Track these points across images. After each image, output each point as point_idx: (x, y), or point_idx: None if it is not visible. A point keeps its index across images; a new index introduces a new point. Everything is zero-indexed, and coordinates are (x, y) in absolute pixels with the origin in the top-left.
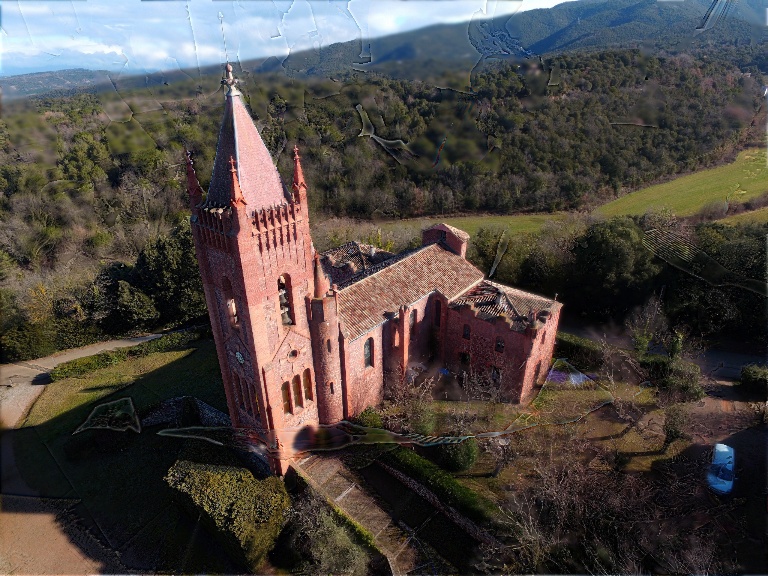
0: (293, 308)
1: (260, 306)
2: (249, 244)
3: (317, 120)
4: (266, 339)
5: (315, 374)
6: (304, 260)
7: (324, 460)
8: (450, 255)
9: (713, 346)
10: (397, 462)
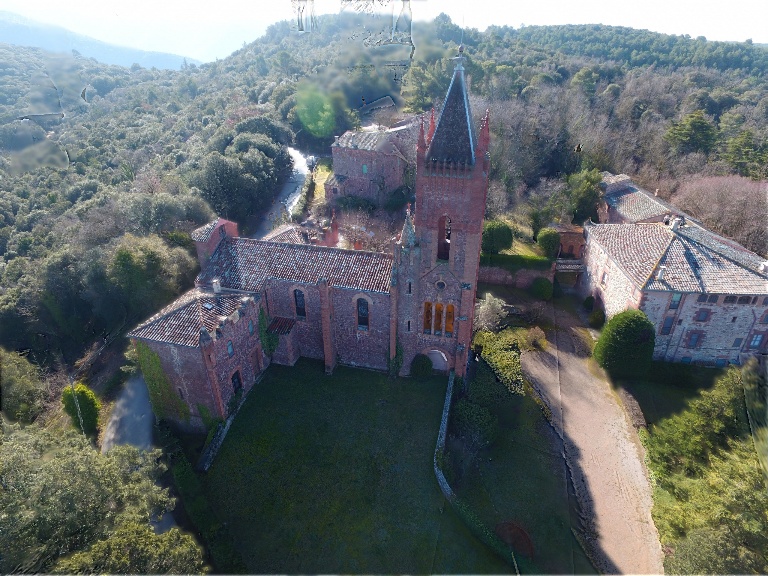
0: None
1: None
2: None
3: None
4: None
5: None
6: None
7: None
8: None
9: (250, 230)
10: None
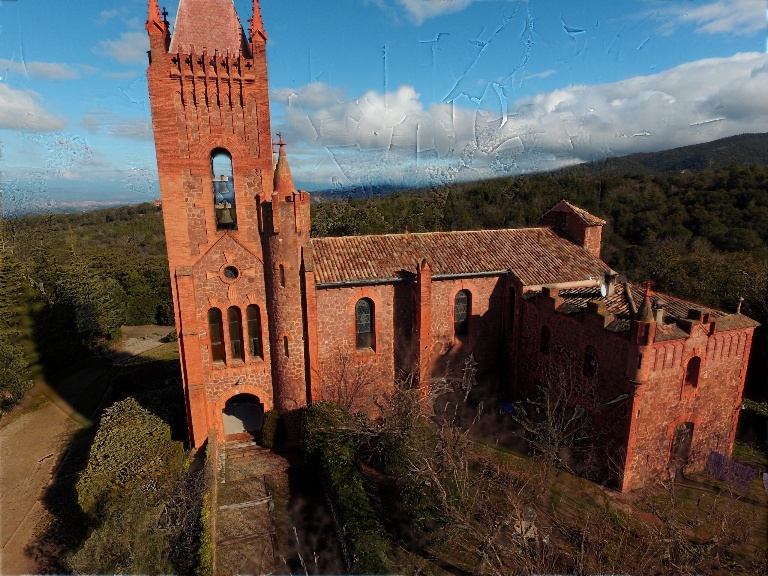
0: (235, 204)
1: (178, 179)
2: (165, 86)
3: (486, 142)
4: (185, 230)
5: (269, 319)
6: (258, 141)
7: (262, 455)
8: (565, 243)
9: None
10: (333, 488)
